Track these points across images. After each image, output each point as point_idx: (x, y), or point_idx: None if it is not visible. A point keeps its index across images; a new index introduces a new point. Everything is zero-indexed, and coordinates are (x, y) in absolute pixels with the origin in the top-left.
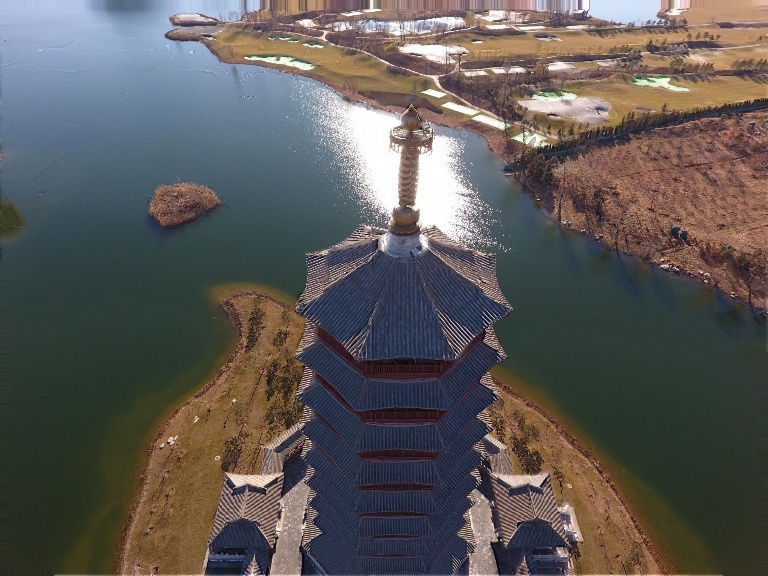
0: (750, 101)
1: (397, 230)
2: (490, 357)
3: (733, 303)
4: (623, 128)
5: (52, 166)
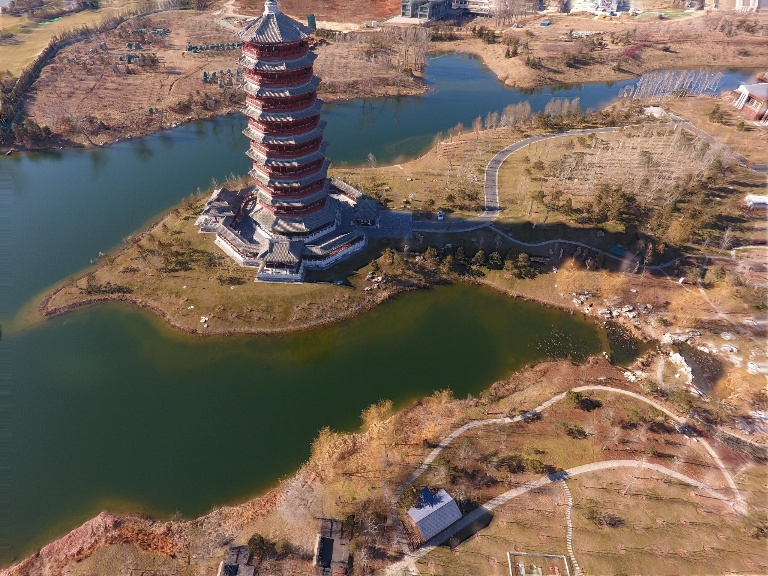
0: (45, 50)
1: (275, 3)
2: None
3: (214, 119)
4: (18, 91)
5: None
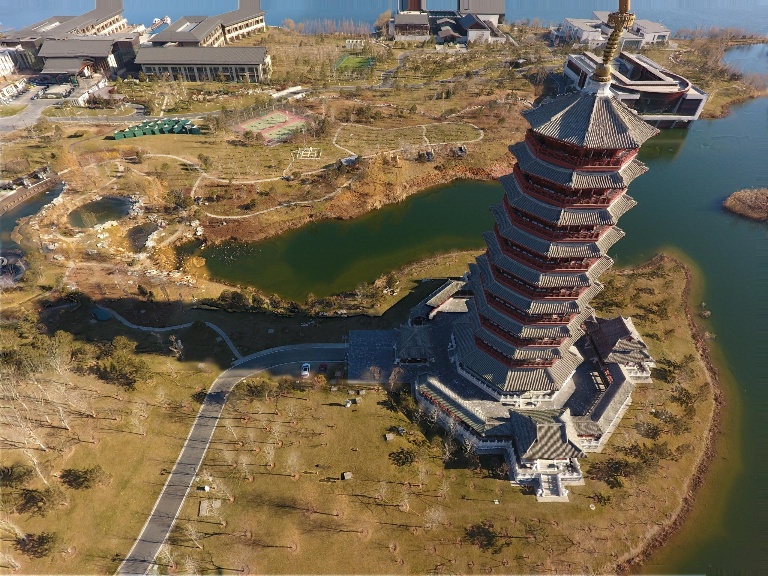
0: None
1: None
2: (566, 180)
3: None
4: None
5: (739, 138)
